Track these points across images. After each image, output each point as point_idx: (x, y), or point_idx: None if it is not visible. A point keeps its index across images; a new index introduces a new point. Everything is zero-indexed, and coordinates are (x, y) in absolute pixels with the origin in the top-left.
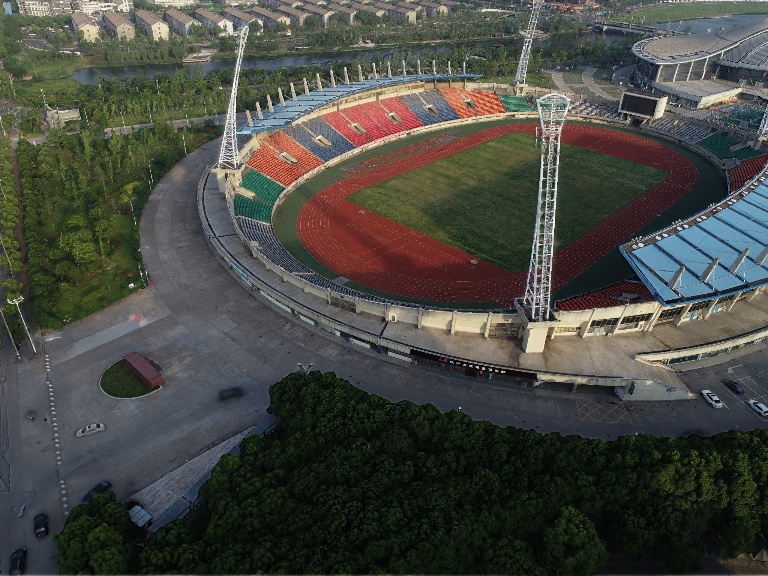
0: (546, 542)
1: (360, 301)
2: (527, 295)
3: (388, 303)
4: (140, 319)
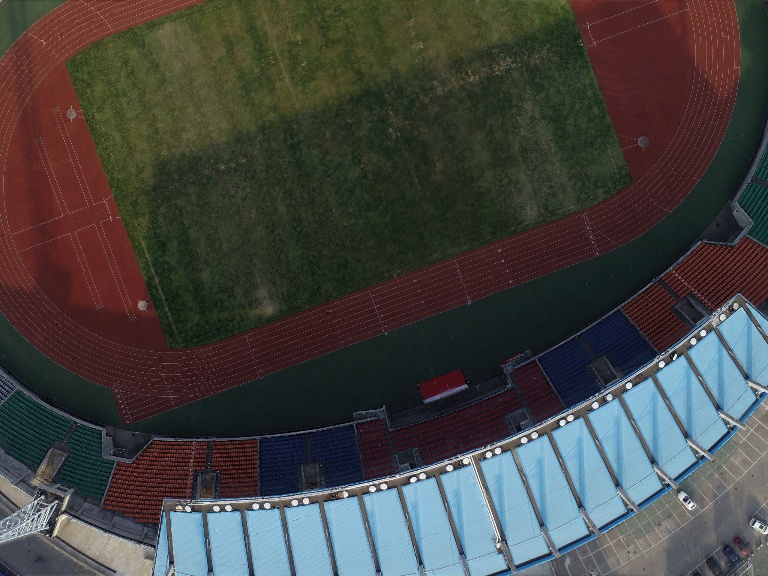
0: None
1: None
2: None
3: None
4: None
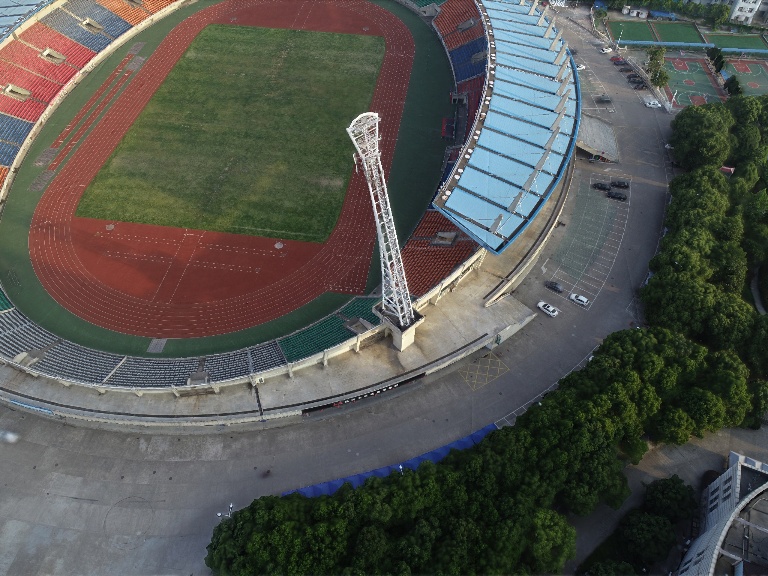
0: (536, 555)
1: (218, 384)
2: (386, 303)
3: (252, 374)
4: None
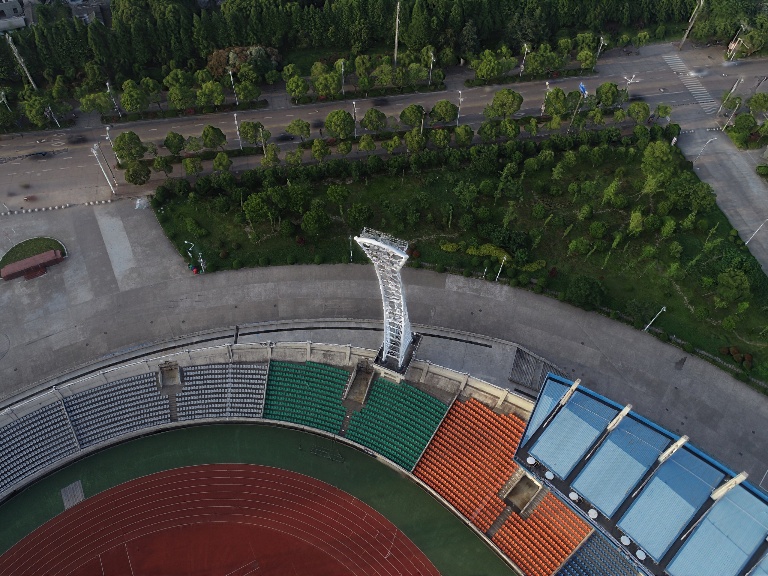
0: None
1: None
2: None
3: None
4: (127, 264)
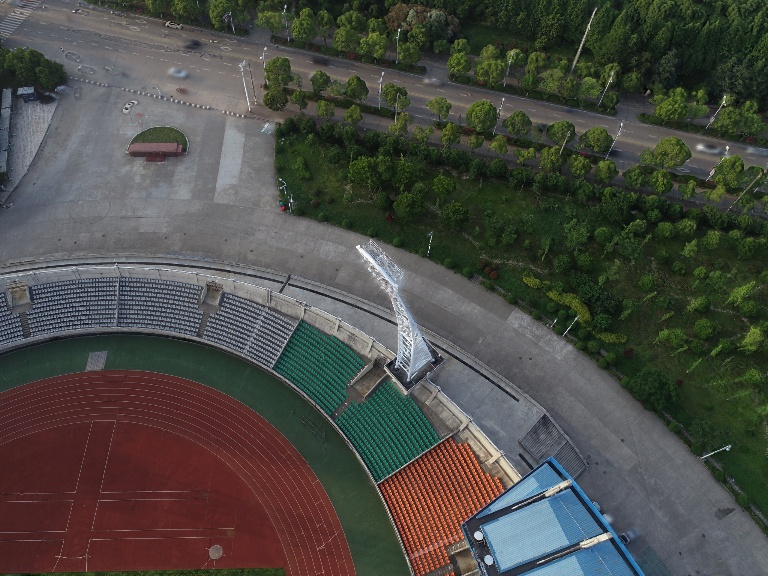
0: None
1: None
2: None
3: None
4: (231, 180)
